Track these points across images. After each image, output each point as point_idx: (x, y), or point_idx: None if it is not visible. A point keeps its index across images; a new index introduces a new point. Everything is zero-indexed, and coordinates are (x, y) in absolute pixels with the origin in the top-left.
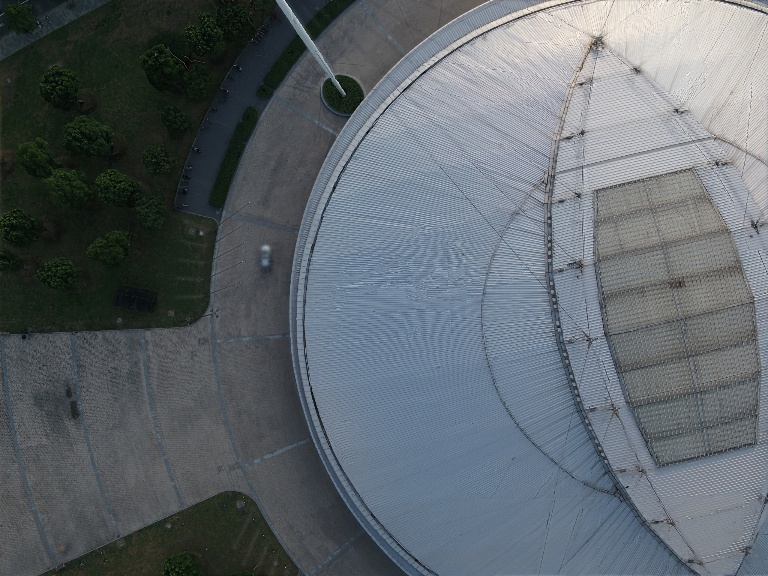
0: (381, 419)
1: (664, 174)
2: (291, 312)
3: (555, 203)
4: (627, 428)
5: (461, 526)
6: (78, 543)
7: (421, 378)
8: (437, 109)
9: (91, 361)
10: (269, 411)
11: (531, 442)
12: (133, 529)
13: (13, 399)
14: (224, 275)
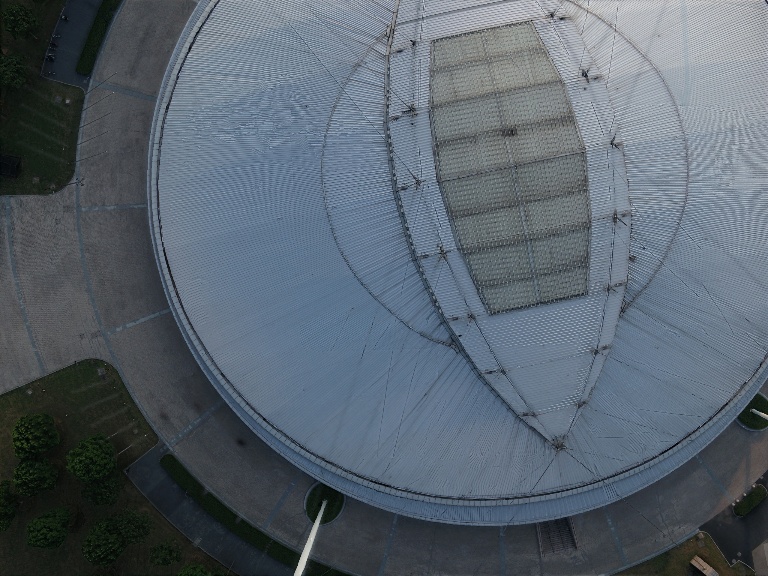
0: (227, 274)
1: (501, 26)
2: (149, 174)
3: (393, 53)
4: (459, 275)
5: (304, 381)
6: None
7: (264, 230)
8: None
9: None
10: (132, 280)
11: (368, 292)
12: None
13: None
14: (90, 144)
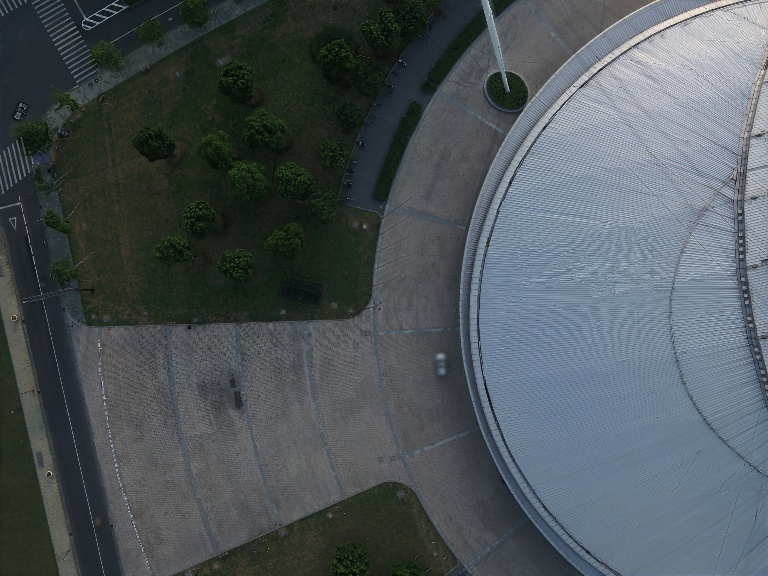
0: (560, 412)
1: None
2: (462, 305)
3: (748, 200)
4: None
5: (639, 519)
6: (241, 531)
7: (605, 372)
8: (618, 106)
9: (255, 352)
10: (430, 403)
11: (718, 436)
12: (295, 518)
13: (178, 388)
14: (387, 268)
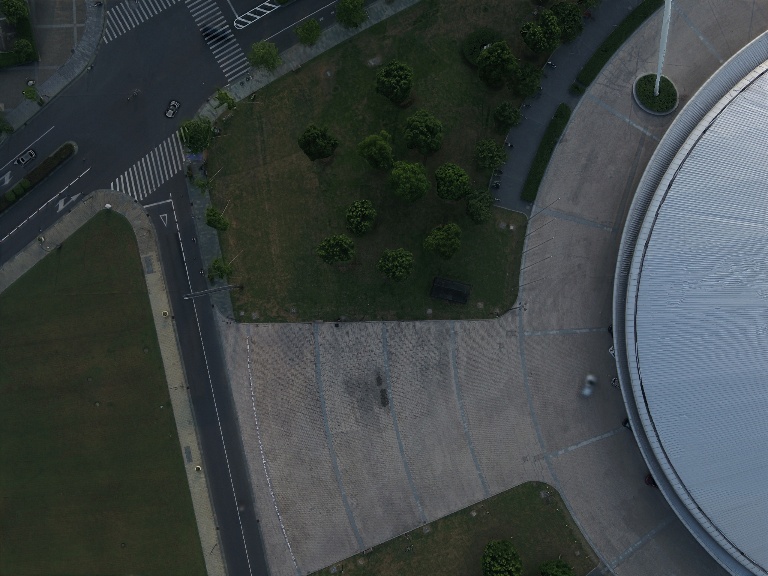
0: (722, 414)
1: None
2: (615, 307)
3: None
4: None
5: None
6: (385, 528)
7: None
8: None
9: (401, 350)
10: (574, 404)
11: None
12: (439, 516)
13: (325, 386)
14: (533, 269)
